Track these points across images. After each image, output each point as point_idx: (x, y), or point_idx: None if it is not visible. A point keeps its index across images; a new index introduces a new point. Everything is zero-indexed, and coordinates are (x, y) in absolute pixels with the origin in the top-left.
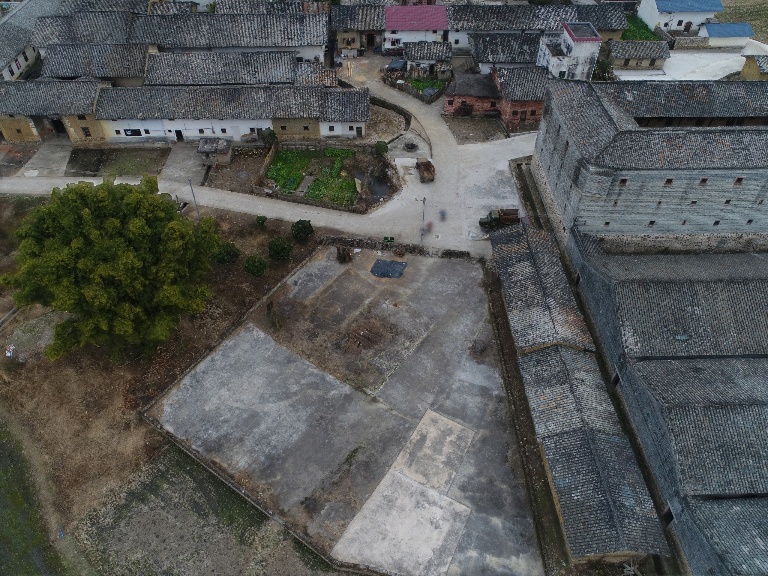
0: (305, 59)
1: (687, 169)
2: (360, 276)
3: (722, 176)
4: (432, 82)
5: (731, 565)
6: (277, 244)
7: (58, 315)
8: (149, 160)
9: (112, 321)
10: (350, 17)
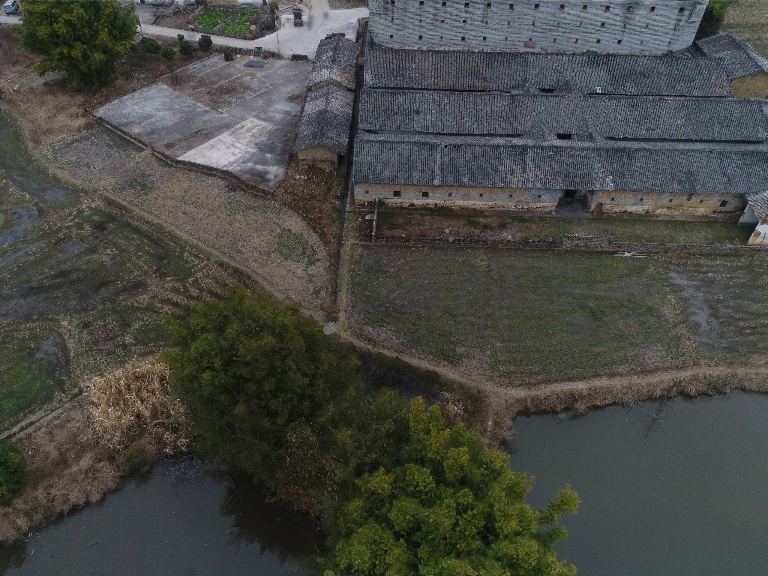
0: None
1: None
2: (236, 66)
3: (455, 1)
4: None
5: (357, 138)
6: (184, 43)
7: (46, 74)
8: None
9: (70, 50)
10: None
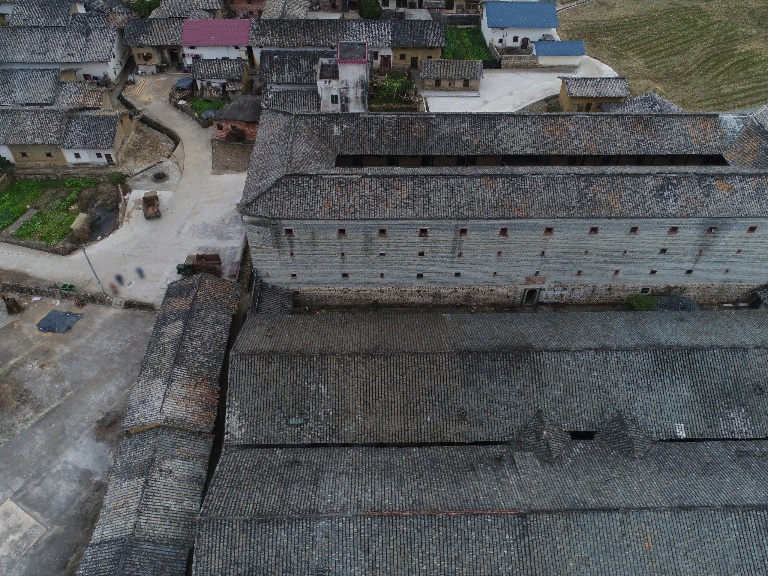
0: (92, 76)
1: (355, 219)
2: (22, 330)
3: (401, 227)
4: (220, 103)
5: None
6: None
7: None
8: None
9: None
10: (144, 31)
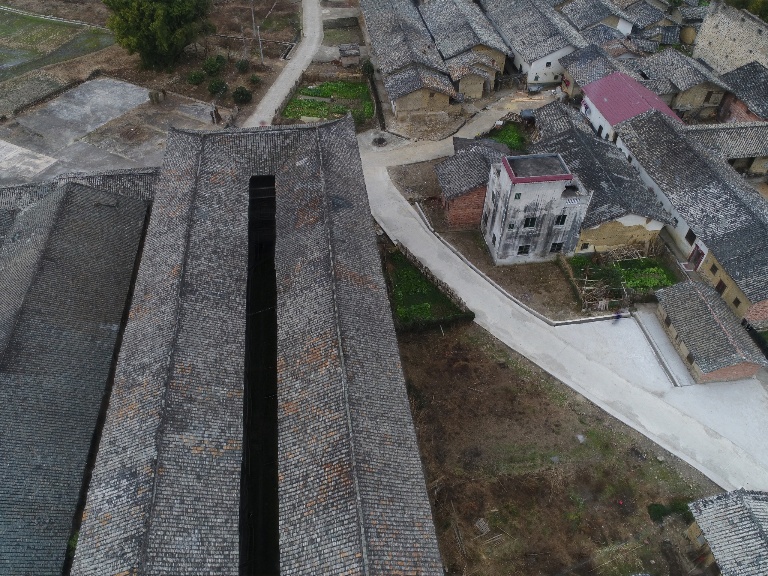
0: (522, 69)
1: None
2: (196, 128)
3: None
4: (518, 147)
5: None
6: None
7: None
8: (347, 41)
9: None
10: (583, 60)
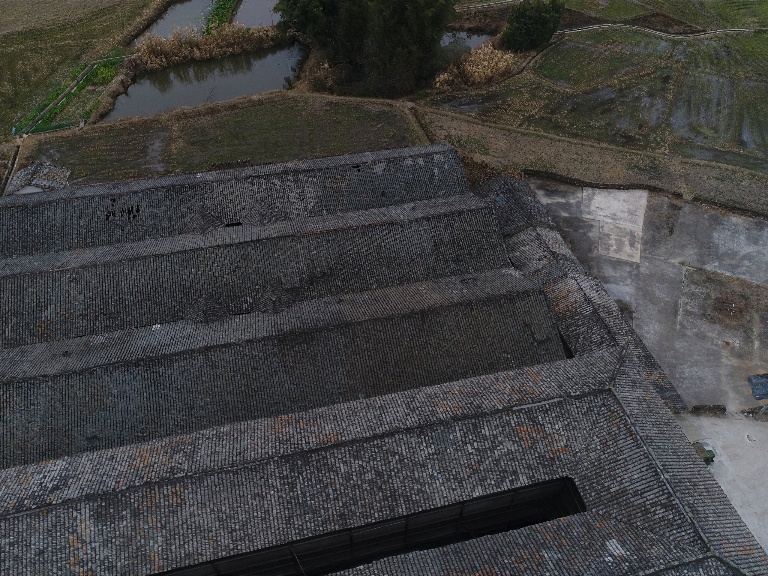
0: None
1: None
2: None
3: None
4: None
5: None
6: None
7: None
8: None
9: None
10: None
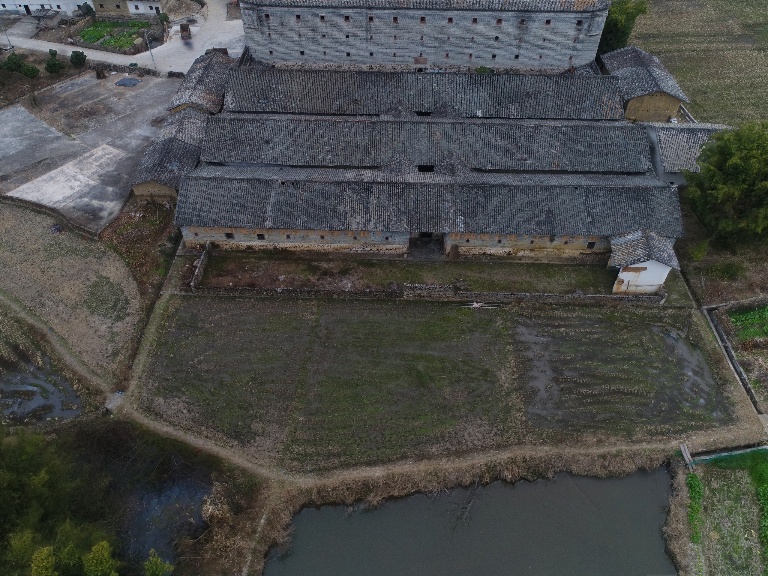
0: None
1: (306, 7)
2: (106, 85)
3: (333, 14)
4: None
5: None
6: (50, 60)
7: None
8: (2, 25)
9: None
10: None
